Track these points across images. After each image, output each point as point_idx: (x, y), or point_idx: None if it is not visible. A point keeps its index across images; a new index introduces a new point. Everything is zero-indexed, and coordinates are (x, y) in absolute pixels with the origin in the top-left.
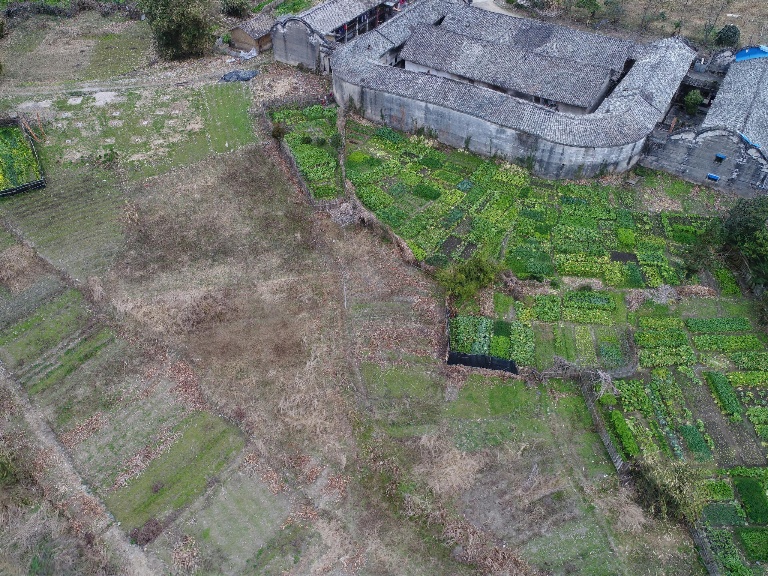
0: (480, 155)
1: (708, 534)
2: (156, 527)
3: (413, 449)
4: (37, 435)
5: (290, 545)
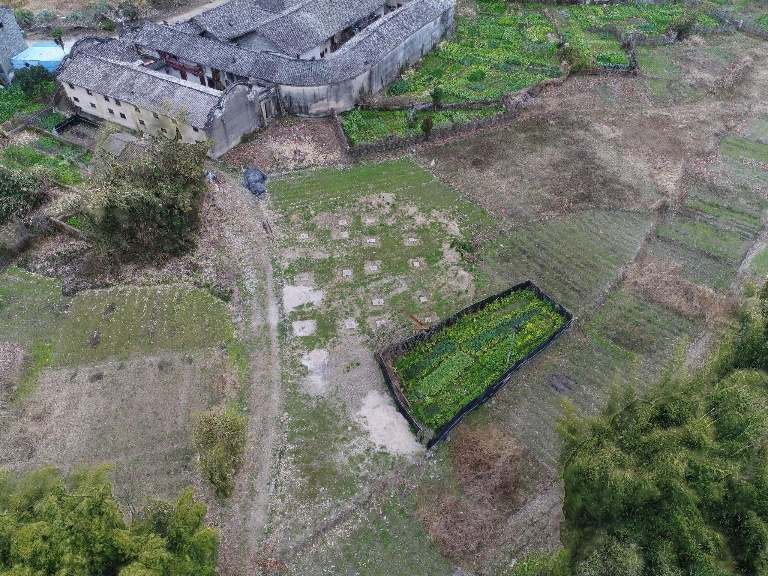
0: (428, 53)
1: None
2: None
3: (700, 84)
4: None
5: None
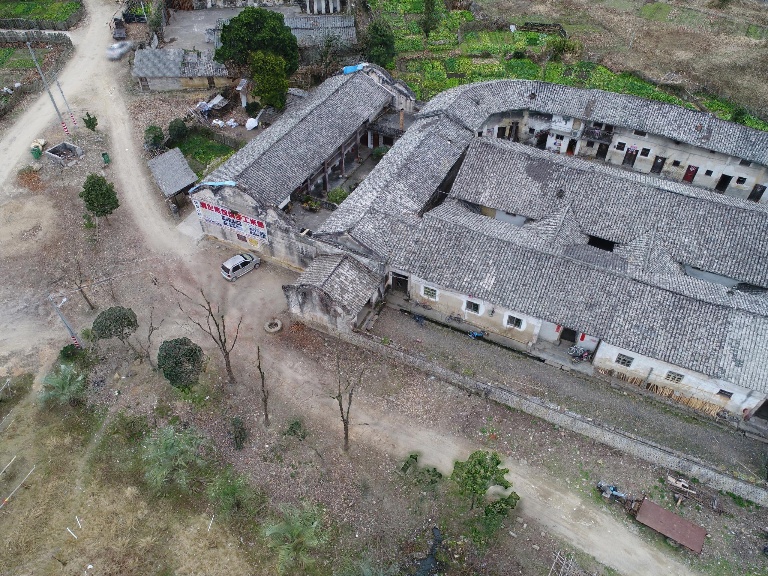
0: None
1: (438, 1)
2: (649, 2)
3: None
4: (730, 16)
5: (595, 0)
